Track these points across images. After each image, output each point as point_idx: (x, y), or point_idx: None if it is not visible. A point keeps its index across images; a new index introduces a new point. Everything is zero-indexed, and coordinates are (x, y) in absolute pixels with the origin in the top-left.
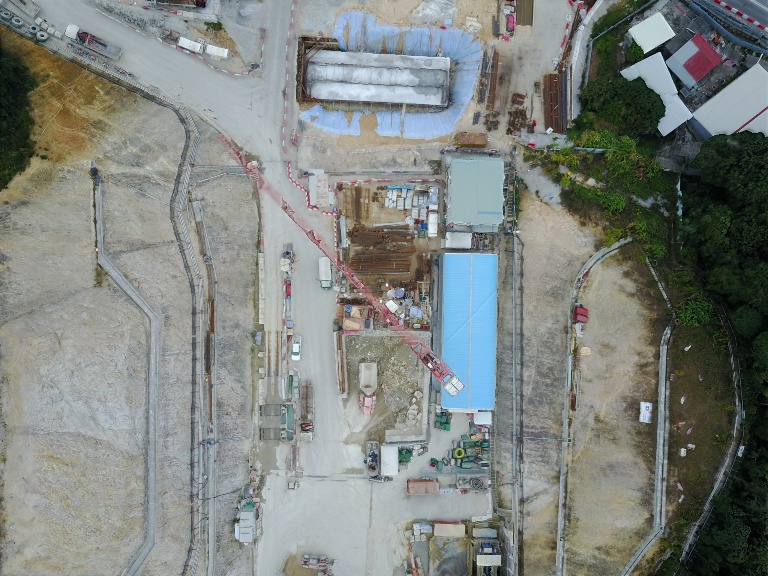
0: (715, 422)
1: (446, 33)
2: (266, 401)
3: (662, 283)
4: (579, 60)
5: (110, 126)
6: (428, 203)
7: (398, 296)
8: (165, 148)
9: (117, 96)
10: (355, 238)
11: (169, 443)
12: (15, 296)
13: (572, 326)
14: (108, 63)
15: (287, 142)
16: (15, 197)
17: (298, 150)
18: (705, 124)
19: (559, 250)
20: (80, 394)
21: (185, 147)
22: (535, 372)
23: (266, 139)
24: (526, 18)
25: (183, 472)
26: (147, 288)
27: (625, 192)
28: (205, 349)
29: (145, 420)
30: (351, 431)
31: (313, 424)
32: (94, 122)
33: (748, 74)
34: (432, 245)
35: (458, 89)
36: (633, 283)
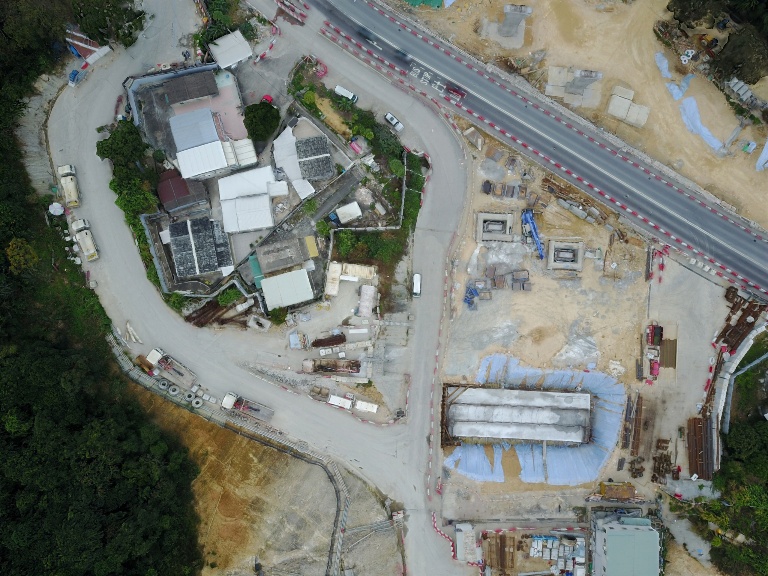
0: None
1: (589, 375)
2: None
3: None
4: None
5: (267, 503)
6: (575, 555)
7: None
8: (319, 519)
9: (270, 461)
10: None
11: None
12: None
13: None
14: (259, 423)
15: (432, 490)
16: None
17: (442, 497)
18: None
19: None
20: None
21: (337, 513)
22: None
23: (410, 486)
24: (669, 360)
25: None
26: None
27: None
28: None
29: None
30: None
31: None
32: (253, 502)
33: None
34: None
35: (600, 428)
36: None
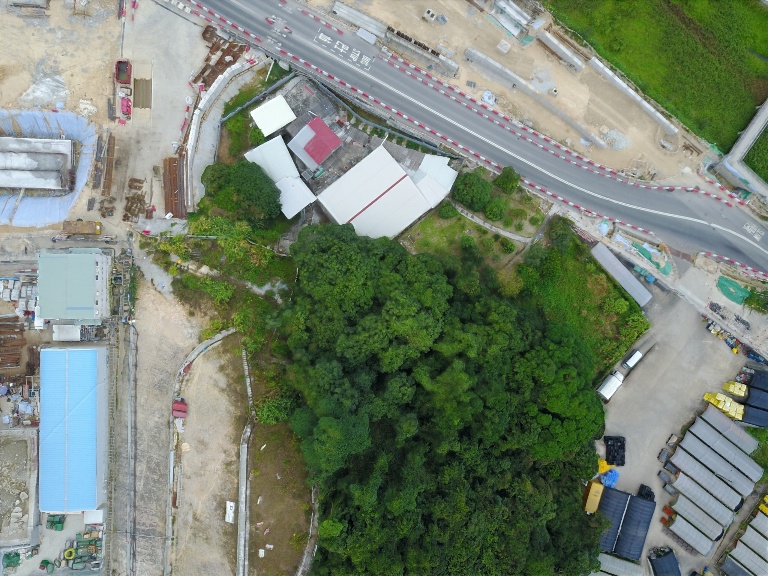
0: (293, 521)
1: (60, 116)
2: None
3: (251, 378)
4: (209, 141)
5: None
6: (36, 294)
7: None
8: None
9: None
10: None
11: None
12: None
13: (173, 421)
14: None
15: None
16: None
17: None
18: (328, 207)
19: (167, 341)
20: None
21: None
22: (145, 467)
23: None
24: (145, 100)
25: None
26: None
27: (240, 279)
28: None
29: None
30: None
31: None
32: None
33: (371, 156)
34: (45, 337)
35: (78, 173)
36: (225, 378)
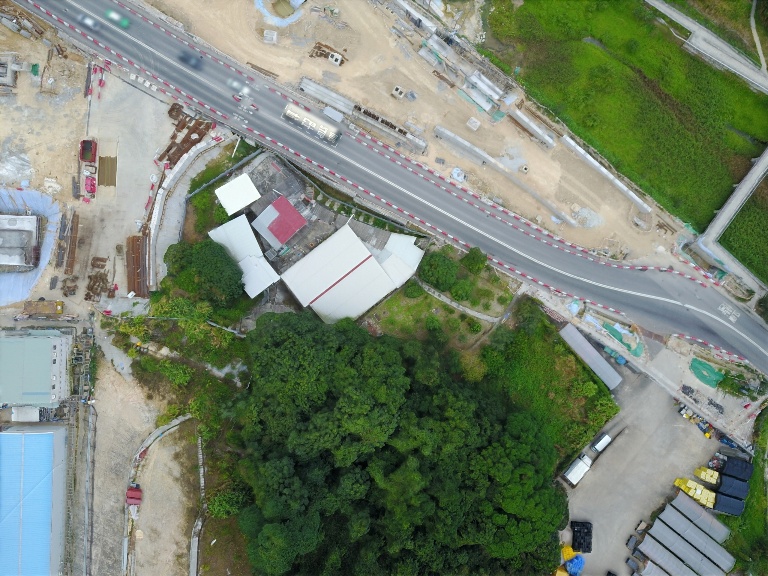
0: None
1: (25, 194)
2: None
3: (205, 468)
4: (174, 217)
5: None
6: None
7: None
8: None
9: None
10: None
11: None
12: None
13: (128, 507)
14: None
15: None
16: None
17: None
18: (292, 287)
19: (125, 424)
20: None
21: None
22: (101, 551)
23: None
24: (110, 178)
25: None
26: None
27: (200, 361)
28: None
29: None
30: None
31: None
32: None
33: (336, 235)
34: (5, 416)
35: (42, 250)
36: (179, 467)
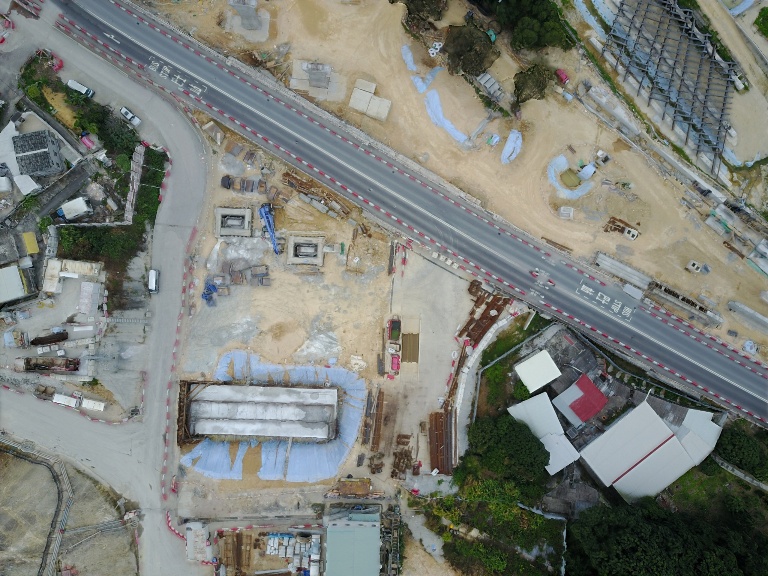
0: None
1: (331, 370)
2: None
3: None
4: (468, 390)
5: None
6: (310, 552)
7: None
8: (34, 519)
9: None
10: None
11: None
12: None
13: None
14: None
15: (167, 488)
16: None
17: (178, 496)
18: (592, 465)
19: None
20: None
21: (56, 513)
22: None
23: (146, 484)
24: (412, 354)
25: None
26: None
27: (509, 543)
28: None
29: None
30: None
31: None
32: None
33: (635, 413)
34: None
35: (344, 424)
36: None
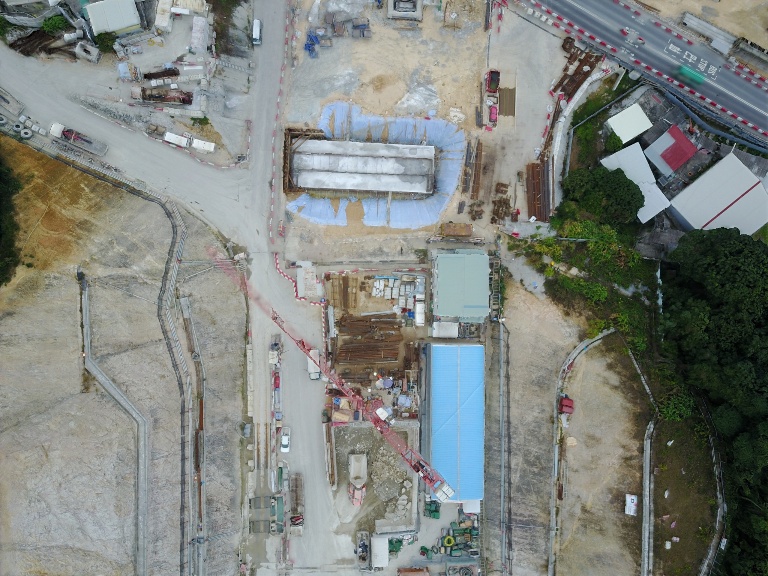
0: (698, 515)
1: (431, 123)
2: (255, 494)
3: (644, 376)
4: (560, 148)
5: (96, 226)
6: (415, 293)
7: (386, 386)
8: (152, 246)
9: (103, 193)
10: (343, 328)
11: (158, 548)
12: (1, 409)
13: (558, 416)
14: (94, 159)
15: (274, 233)
16: (0, 309)
17: (285, 241)
18: (682, 212)
19: (544, 339)
20: (68, 506)
21: (172, 243)
22: (522, 460)
23: (253, 230)
24: (508, 108)
25: (173, 575)
26: (135, 391)
27: (607, 281)
28: (194, 447)
29: (134, 527)
30: (341, 522)
31: (303, 516)
32: (80, 223)
33: (722, 163)
34: (419, 333)
35: (443, 177)
36: (616, 375)
